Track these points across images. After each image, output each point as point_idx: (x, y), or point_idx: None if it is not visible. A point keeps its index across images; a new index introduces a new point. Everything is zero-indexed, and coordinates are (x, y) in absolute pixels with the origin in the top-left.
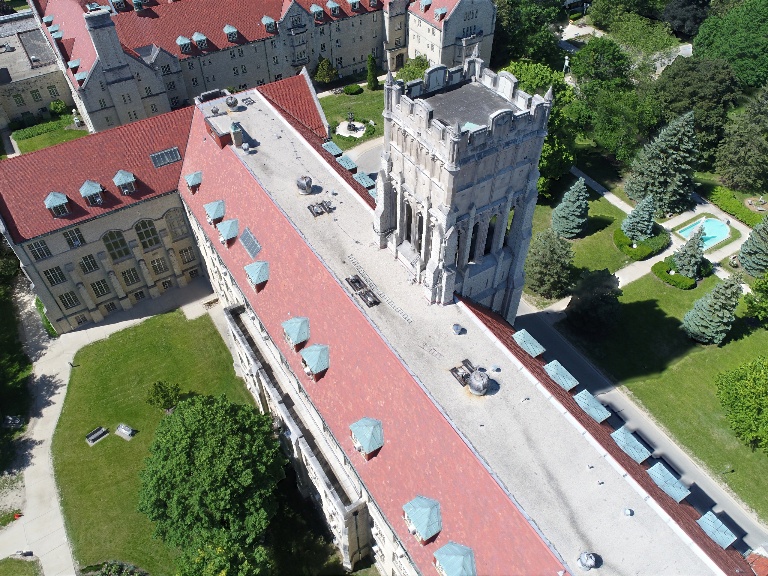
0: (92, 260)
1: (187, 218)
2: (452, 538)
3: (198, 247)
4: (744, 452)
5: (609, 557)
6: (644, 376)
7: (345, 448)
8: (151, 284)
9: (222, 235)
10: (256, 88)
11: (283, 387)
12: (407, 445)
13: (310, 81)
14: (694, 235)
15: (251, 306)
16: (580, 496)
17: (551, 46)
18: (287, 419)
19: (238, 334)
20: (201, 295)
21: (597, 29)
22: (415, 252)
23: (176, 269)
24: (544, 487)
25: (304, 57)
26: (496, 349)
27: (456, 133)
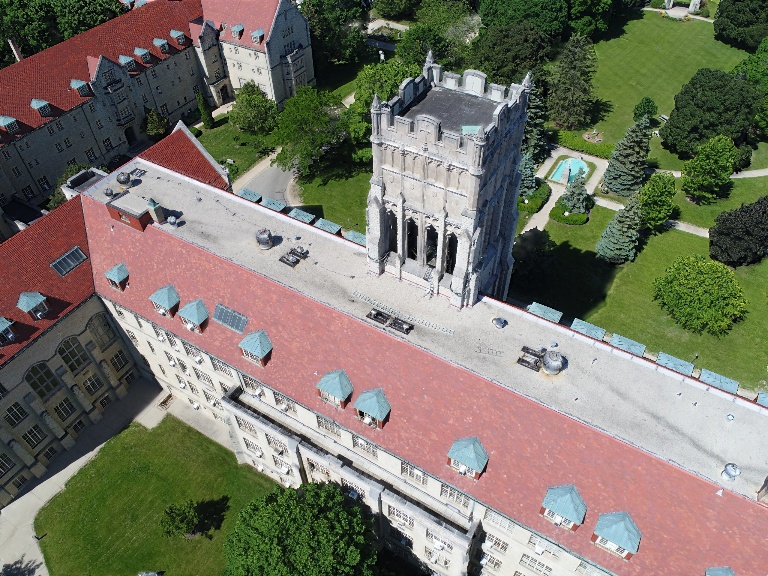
0: (18, 408)
1: (112, 320)
2: (601, 511)
3: (132, 347)
4: (695, 339)
5: (740, 461)
6: (595, 308)
7: (446, 478)
8: (90, 408)
9: (191, 321)
10: (138, 156)
11: (331, 450)
12: (516, 447)
13: (191, 134)
14: (575, 176)
15: (261, 383)
16: (688, 422)
17: (364, 44)
18: (359, 479)
19: (254, 417)
20: (150, 398)
21: (387, 20)
22: (424, 266)
23: (112, 381)
24: (658, 428)
25: (128, 113)
26: (542, 327)
27: (482, 137)
